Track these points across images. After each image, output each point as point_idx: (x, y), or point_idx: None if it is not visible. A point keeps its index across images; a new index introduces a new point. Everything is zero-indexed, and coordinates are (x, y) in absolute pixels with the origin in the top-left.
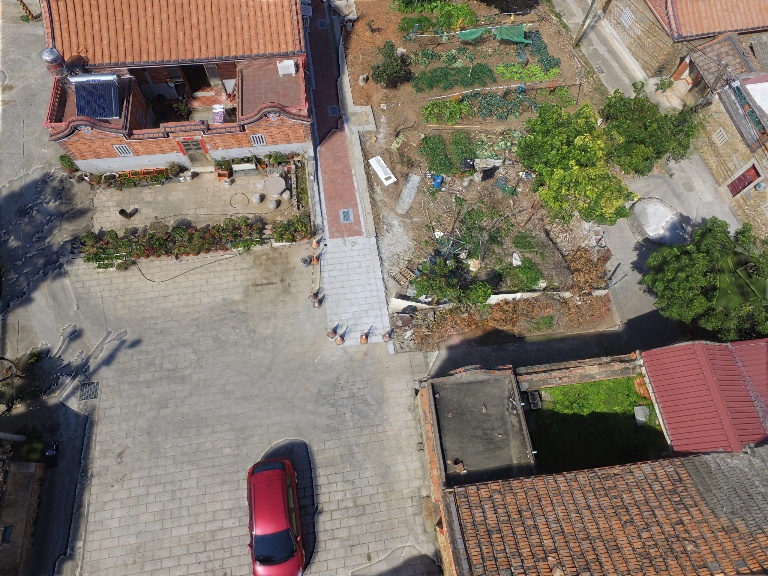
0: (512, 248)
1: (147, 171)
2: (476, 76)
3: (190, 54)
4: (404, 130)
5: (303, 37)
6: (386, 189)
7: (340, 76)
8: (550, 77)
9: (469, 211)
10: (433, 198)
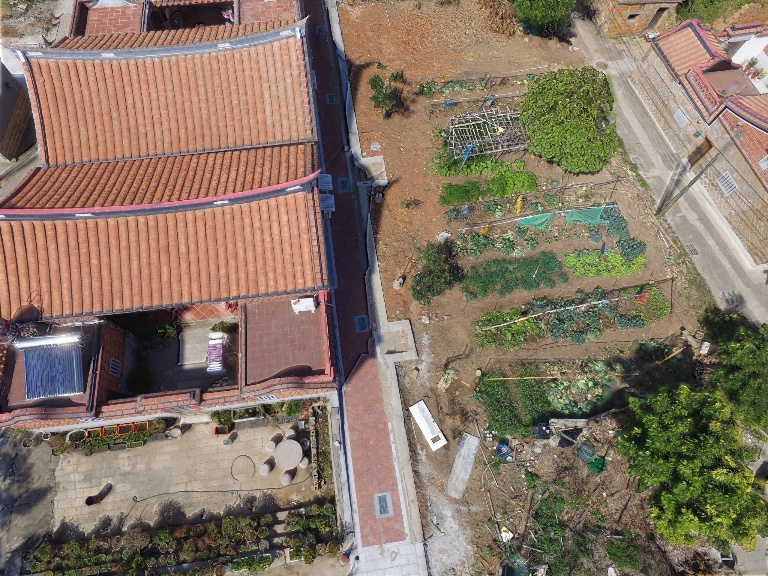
0: (606, 559)
1: (125, 425)
2: (542, 275)
3: (177, 296)
4: (453, 360)
5: (325, 266)
6: (434, 456)
7: (368, 269)
8: (634, 270)
9: (546, 499)
10: (496, 472)
